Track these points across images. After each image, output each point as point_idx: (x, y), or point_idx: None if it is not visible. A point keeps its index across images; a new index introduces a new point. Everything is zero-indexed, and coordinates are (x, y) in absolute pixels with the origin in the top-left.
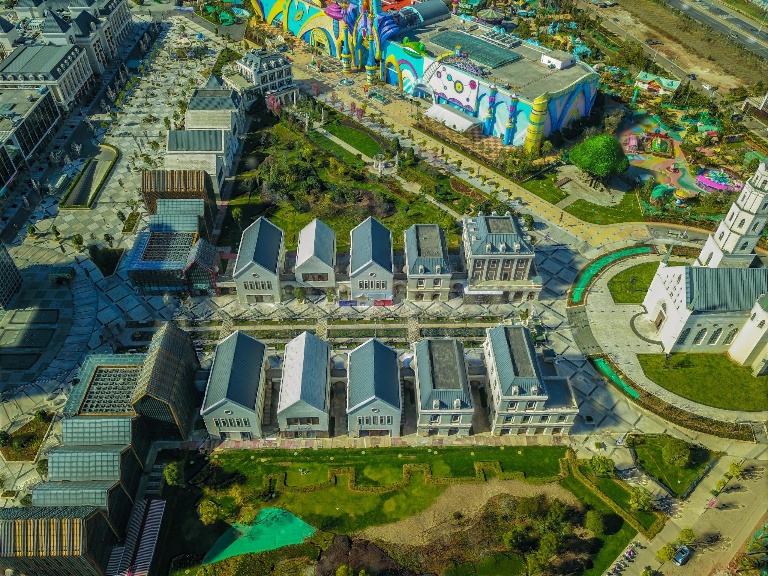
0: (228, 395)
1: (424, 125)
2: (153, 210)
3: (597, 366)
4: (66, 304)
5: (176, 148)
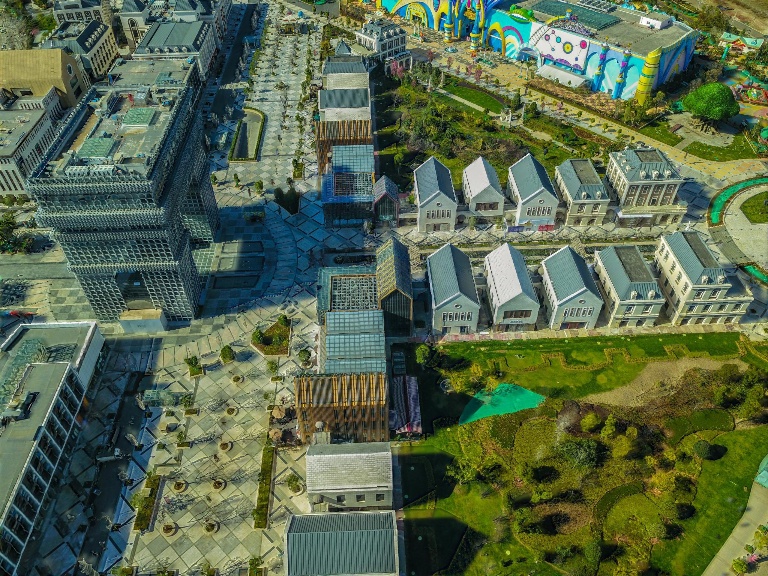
0: (460, 290)
1: (534, 84)
2: (323, 157)
3: (748, 272)
4: (265, 237)
5: (327, 106)
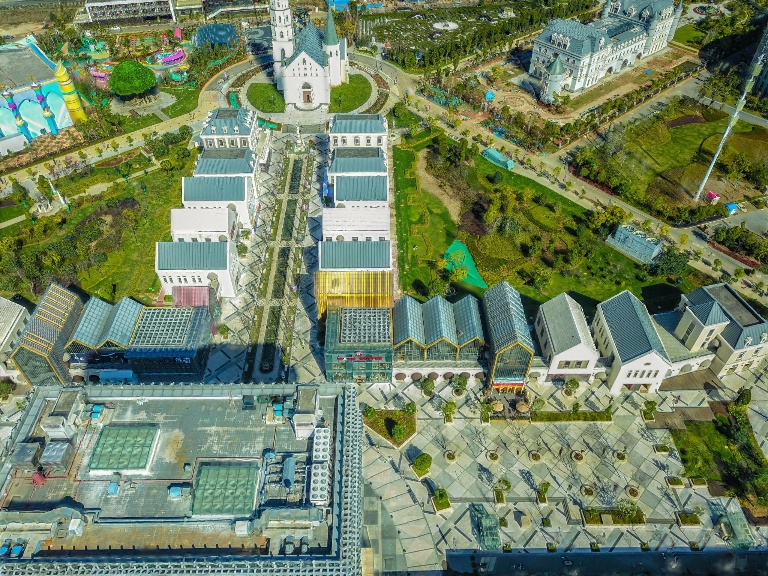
0: None
1: None
2: (62, 368)
3: None
4: None
5: None
